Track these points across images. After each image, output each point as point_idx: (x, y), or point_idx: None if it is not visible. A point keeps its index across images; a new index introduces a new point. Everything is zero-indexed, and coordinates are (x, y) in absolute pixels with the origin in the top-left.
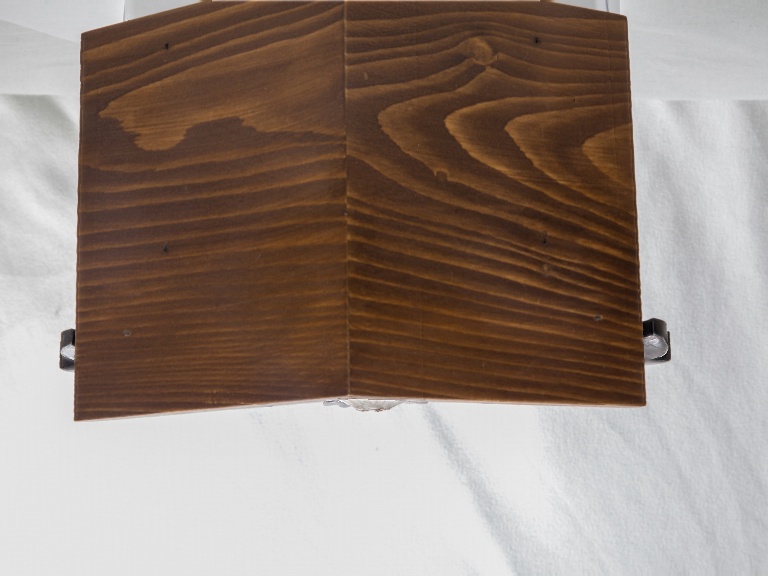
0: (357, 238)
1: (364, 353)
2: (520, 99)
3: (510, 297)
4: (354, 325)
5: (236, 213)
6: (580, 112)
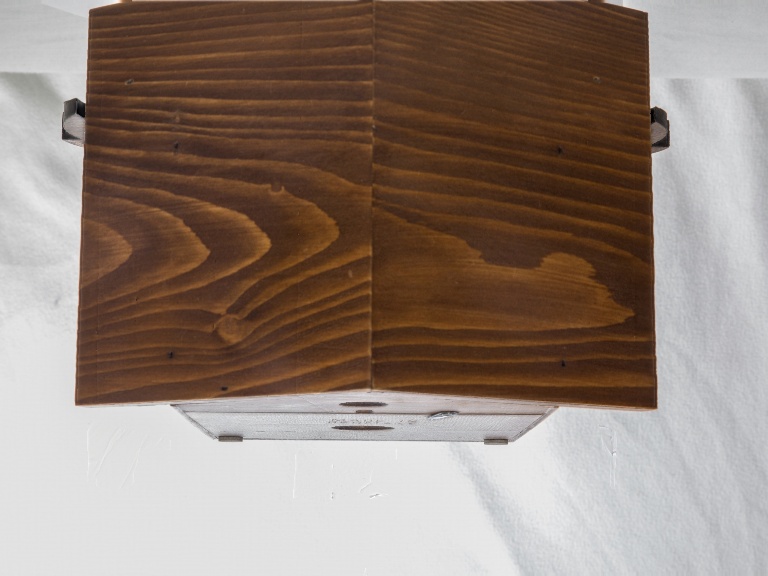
0: (363, 104)
1: None
2: (193, 287)
3: (214, 82)
4: (368, 19)
5: (487, 163)
6: (132, 288)
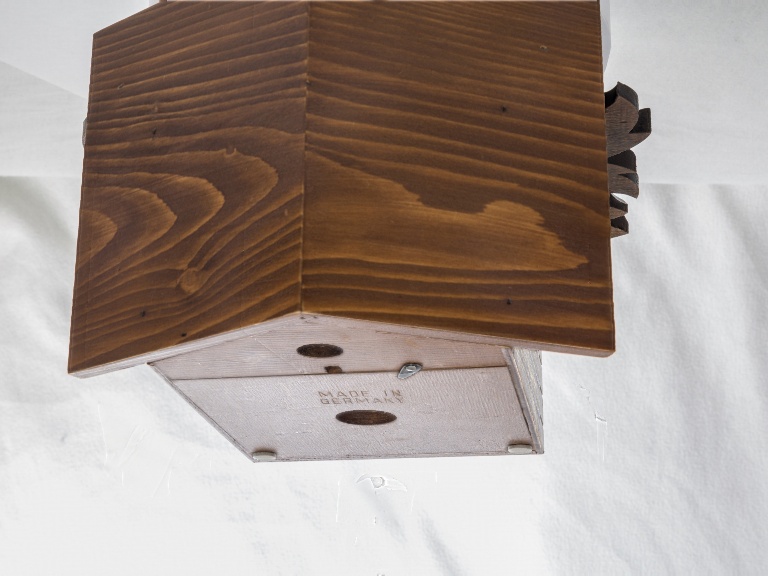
0: (299, 64)
1: None
2: (162, 251)
3: (185, 71)
4: None
5: (426, 118)
6: (116, 261)
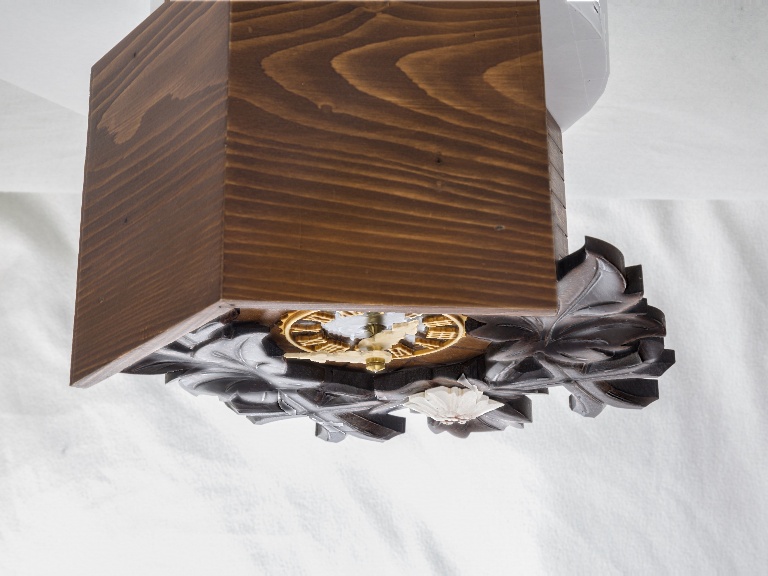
0: (236, 165)
1: (238, 263)
2: (413, 38)
3: (398, 211)
4: (229, 239)
5: (165, 173)
6: (481, 45)
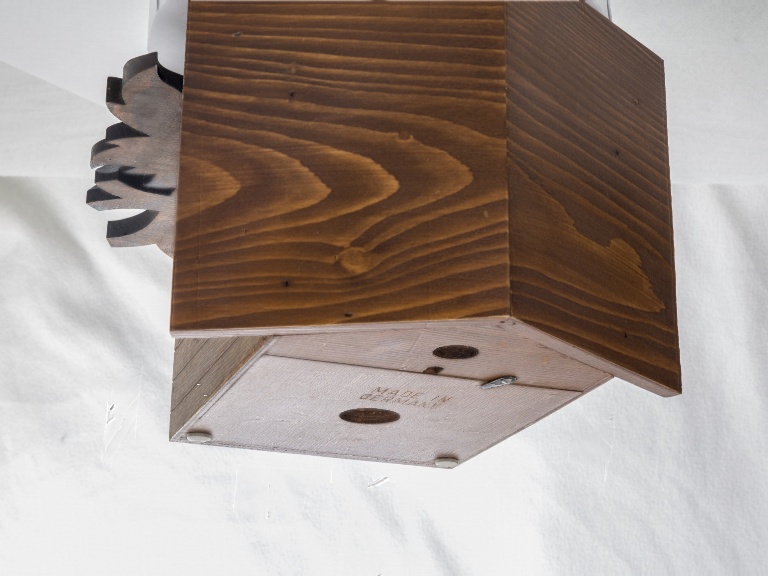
0: (496, 69)
1: None
2: (311, 222)
3: (335, 40)
4: None
5: (576, 147)
6: (240, 221)
